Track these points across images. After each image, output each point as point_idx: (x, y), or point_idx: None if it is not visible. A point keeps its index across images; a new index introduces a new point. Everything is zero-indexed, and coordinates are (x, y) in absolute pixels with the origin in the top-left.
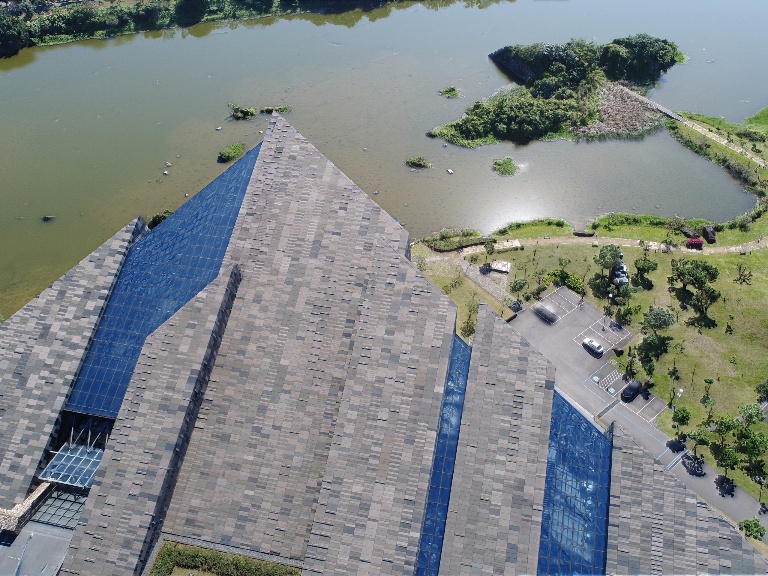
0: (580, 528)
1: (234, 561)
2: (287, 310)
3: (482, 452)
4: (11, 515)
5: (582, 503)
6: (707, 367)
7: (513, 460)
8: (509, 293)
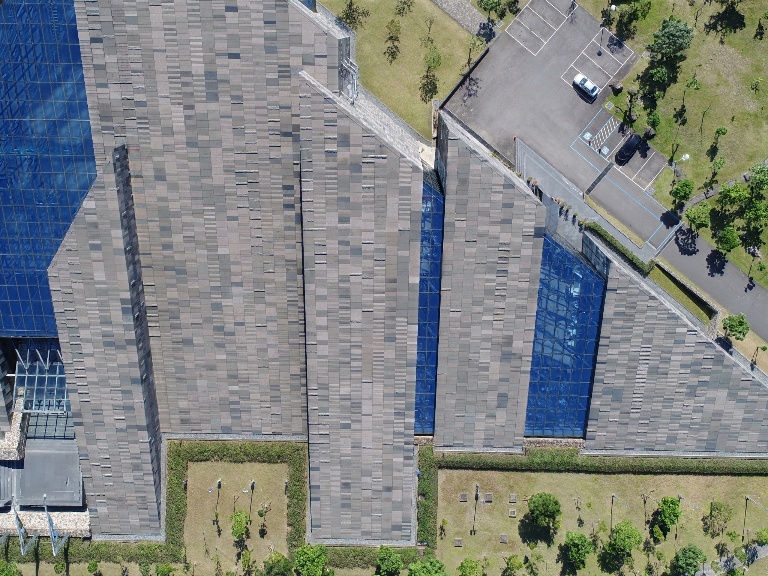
0: (566, 336)
1: (242, 449)
2: (203, 184)
3: (467, 316)
4: (7, 448)
5: None
6: (722, 101)
7: (500, 319)
8: (476, 9)
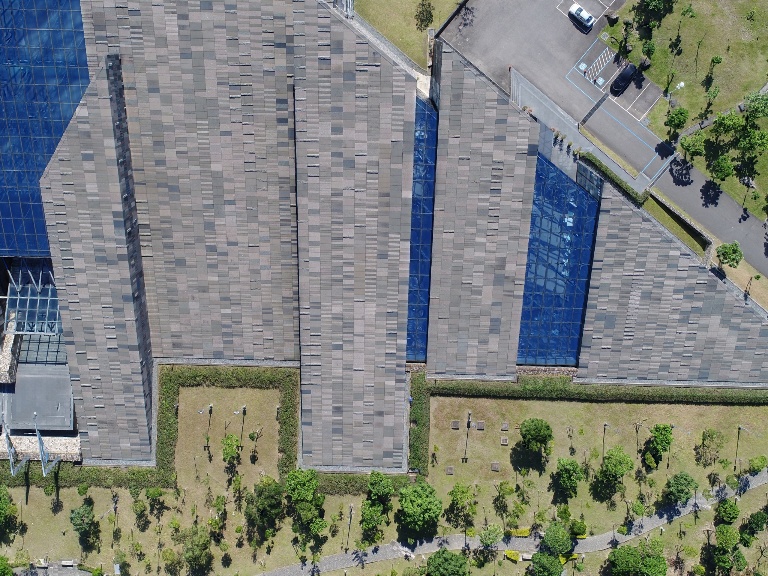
0: (559, 267)
1: (233, 374)
2: (197, 97)
3: (460, 237)
4: None
5: (562, 238)
6: (717, 31)
7: (493, 240)
8: None
